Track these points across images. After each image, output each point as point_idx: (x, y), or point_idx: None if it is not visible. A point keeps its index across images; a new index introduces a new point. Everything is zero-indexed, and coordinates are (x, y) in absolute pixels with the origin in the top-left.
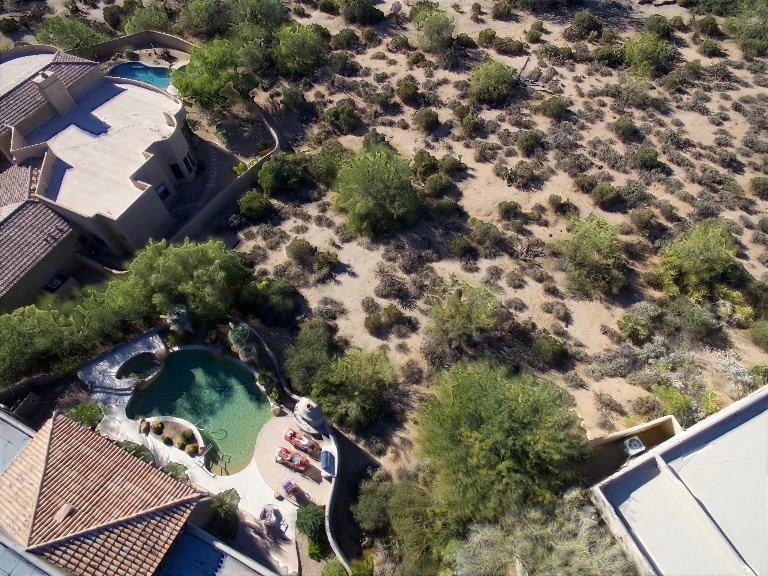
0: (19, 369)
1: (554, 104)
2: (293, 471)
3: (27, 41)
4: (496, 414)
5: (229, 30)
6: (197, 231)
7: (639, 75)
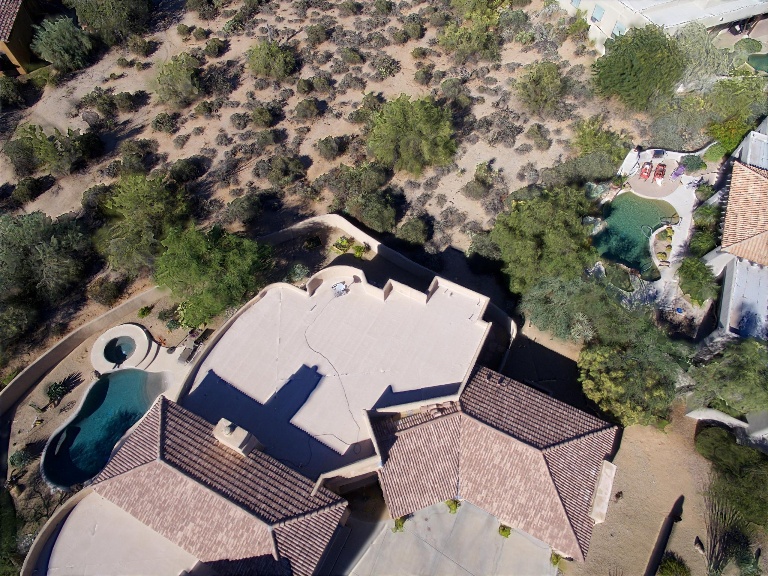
0: None
1: (320, 30)
2: (664, 177)
3: None
4: None
5: None
6: None
7: None
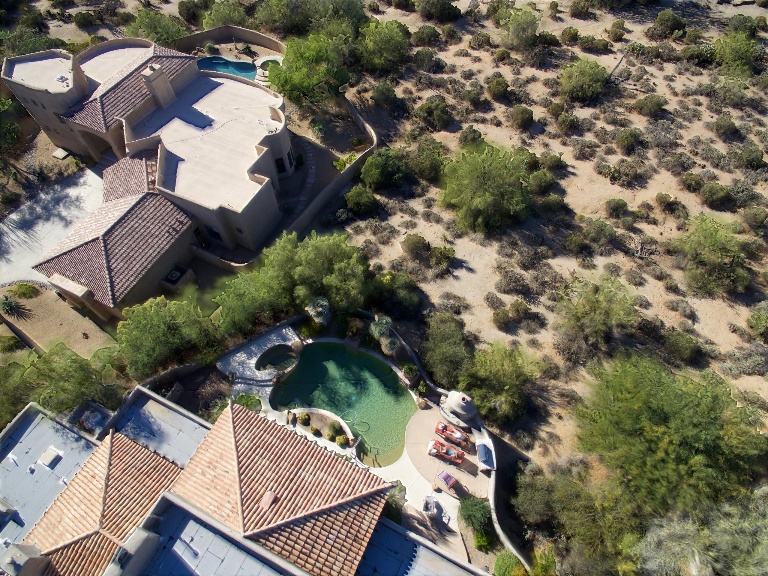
0: (157, 359)
1: (652, 103)
2: (448, 464)
3: (102, 35)
4: (679, 409)
5: (307, 26)
6: (305, 225)
7: (730, 75)
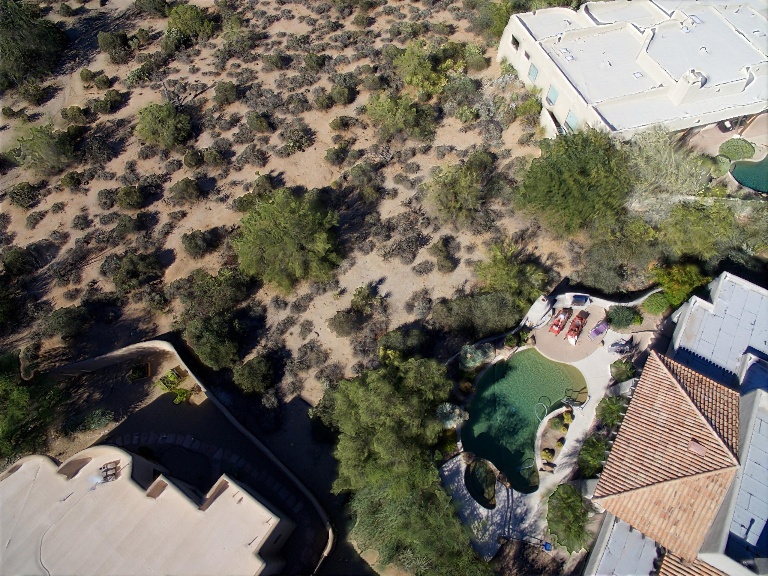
0: None
1: (228, 90)
2: (582, 332)
3: None
4: None
5: None
6: None
7: (211, 36)
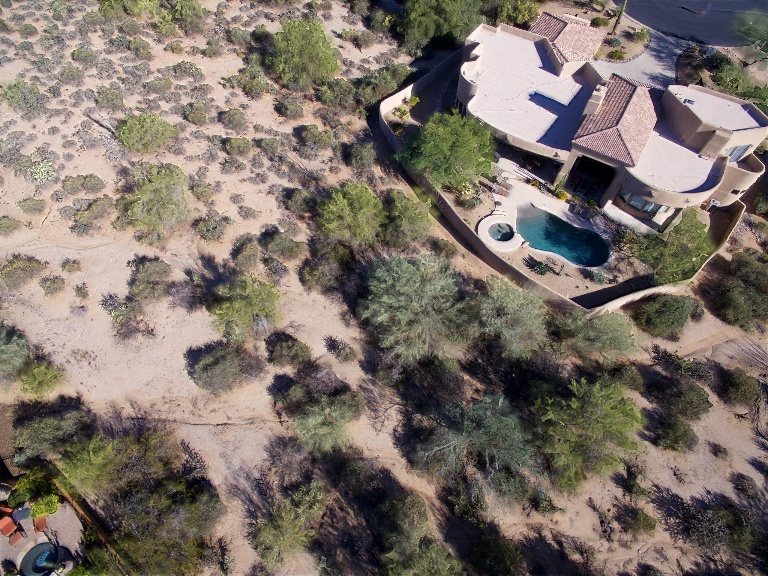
0: None
1: None
2: None
3: None
4: None
5: None
6: (442, 72)
7: None
